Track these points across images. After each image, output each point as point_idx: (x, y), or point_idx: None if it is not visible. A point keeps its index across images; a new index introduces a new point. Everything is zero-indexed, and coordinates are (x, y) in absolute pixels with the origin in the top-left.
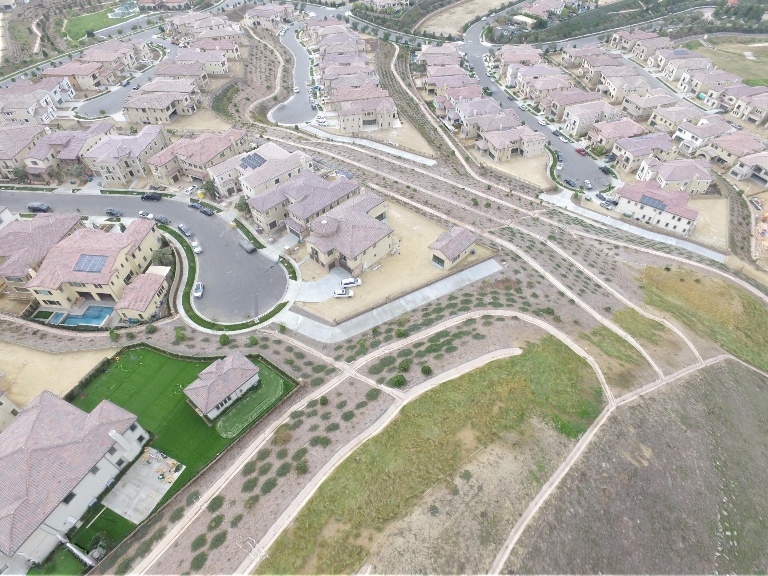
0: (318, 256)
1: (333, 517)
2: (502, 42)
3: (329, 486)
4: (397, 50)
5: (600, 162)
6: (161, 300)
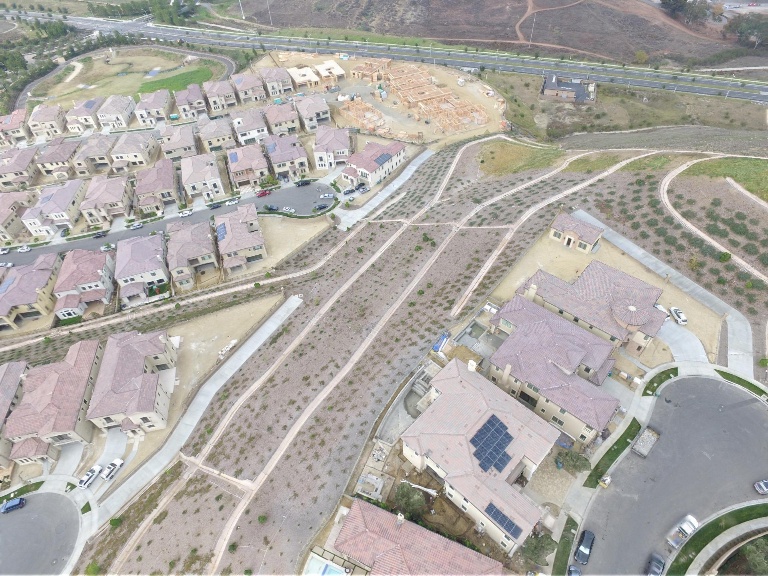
0: None
1: None
2: None
3: None
4: None
5: (286, 185)
6: None
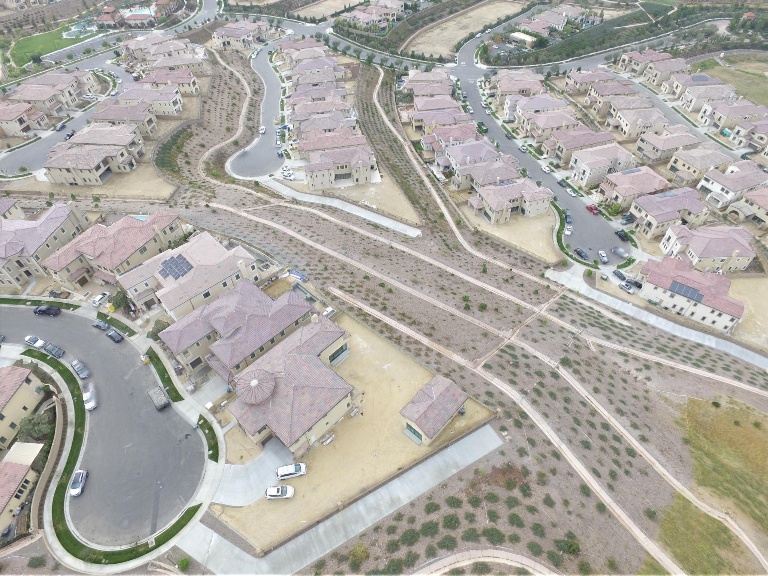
0: (245, 432)
1: None
2: (498, 64)
3: None
4: (381, 75)
5: (616, 224)
6: (23, 501)
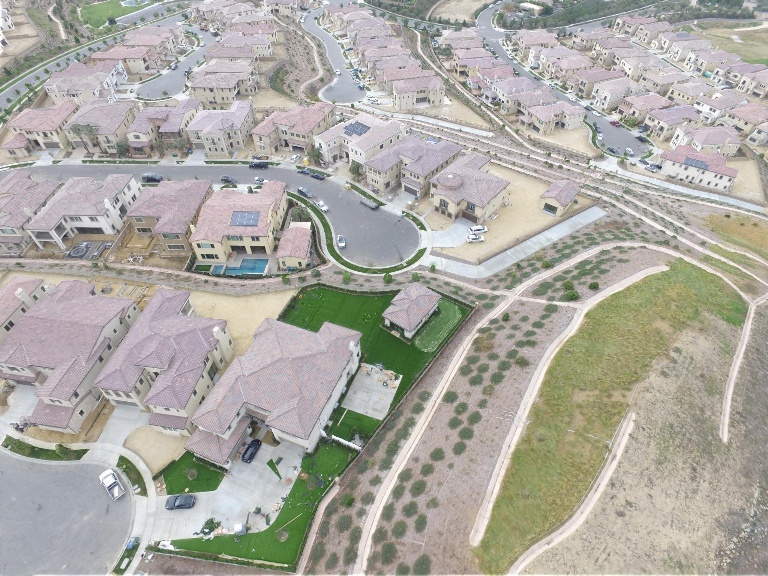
0: (448, 207)
1: (577, 389)
2: (514, 27)
3: (558, 370)
4: (418, 35)
5: (635, 132)
6: (309, 251)
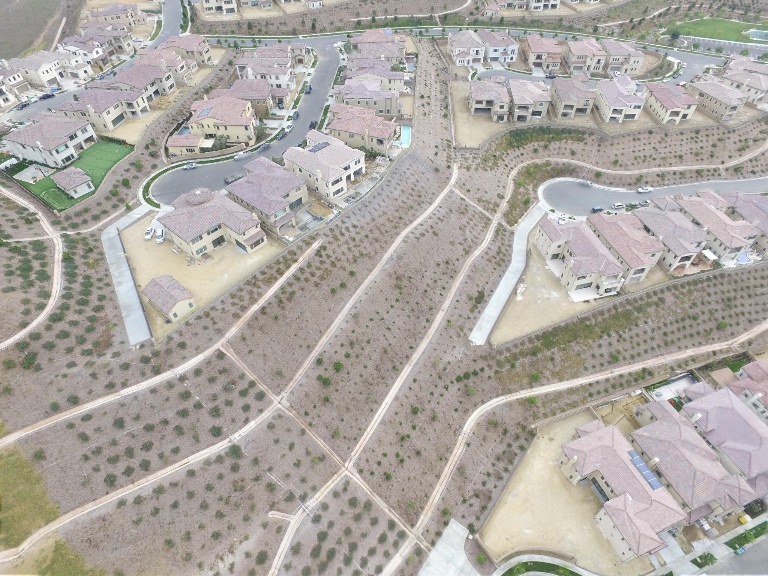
0: None
1: None
2: None
3: None
4: None
5: None
6: None
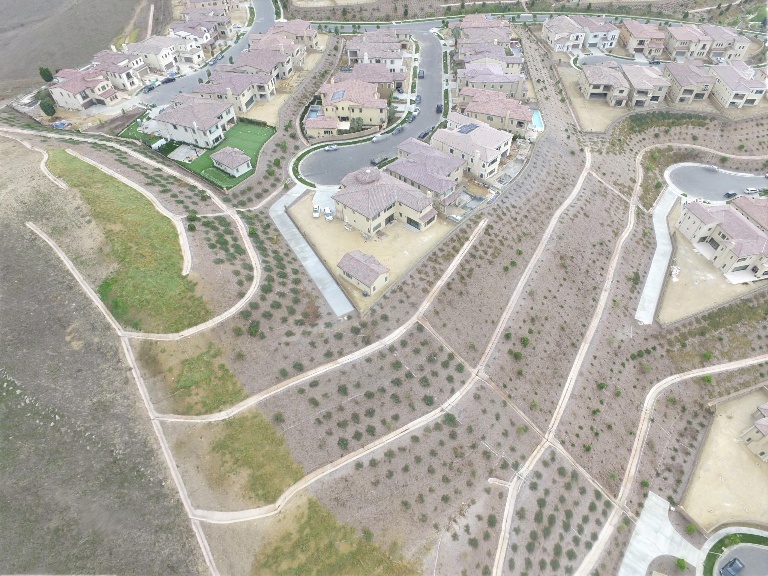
0: None
1: None
2: None
3: None
4: None
5: None
6: None
